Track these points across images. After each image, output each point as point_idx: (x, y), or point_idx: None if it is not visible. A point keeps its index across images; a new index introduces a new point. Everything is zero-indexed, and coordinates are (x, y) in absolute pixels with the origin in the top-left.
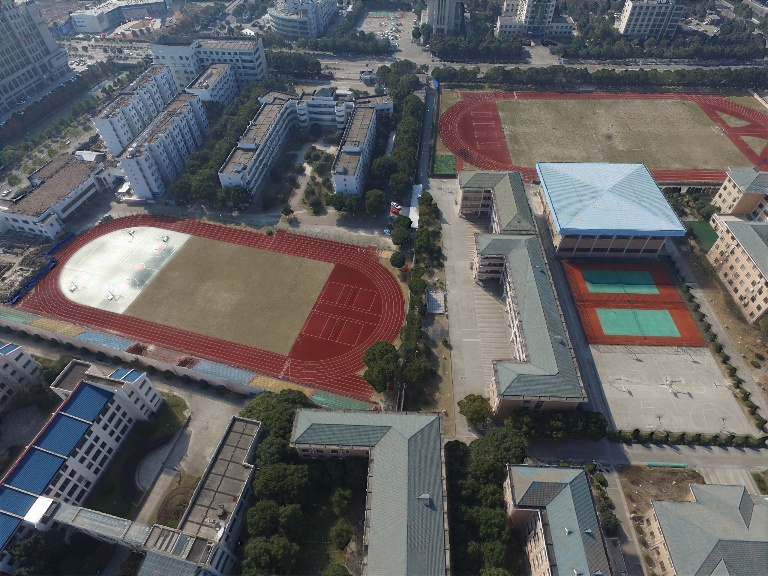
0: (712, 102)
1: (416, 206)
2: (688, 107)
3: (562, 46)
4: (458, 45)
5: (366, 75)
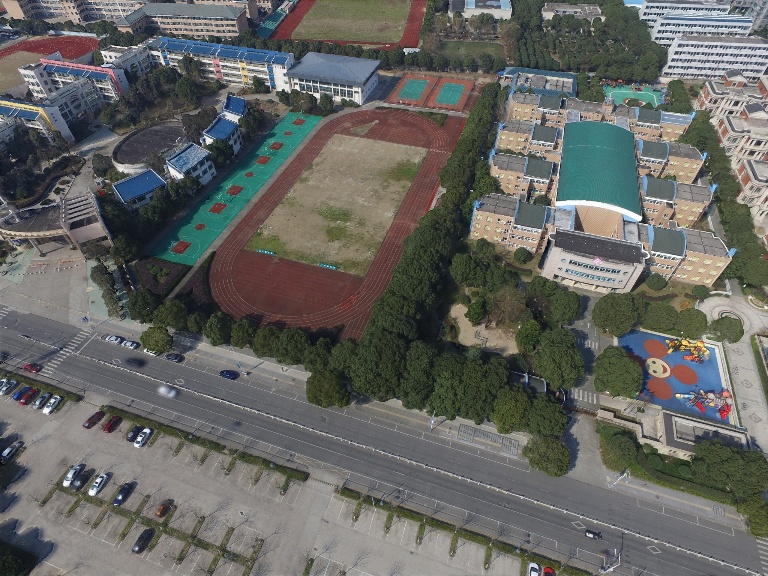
0: None
1: (3, 27)
2: None
3: None
4: None
5: None
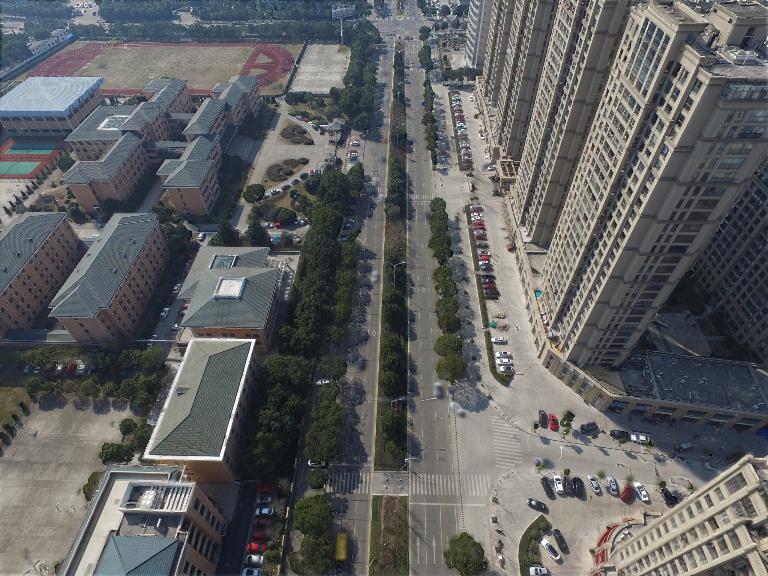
0: (267, 48)
1: None
2: (244, 51)
3: (193, 10)
4: (113, 9)
5: (21, 30)
